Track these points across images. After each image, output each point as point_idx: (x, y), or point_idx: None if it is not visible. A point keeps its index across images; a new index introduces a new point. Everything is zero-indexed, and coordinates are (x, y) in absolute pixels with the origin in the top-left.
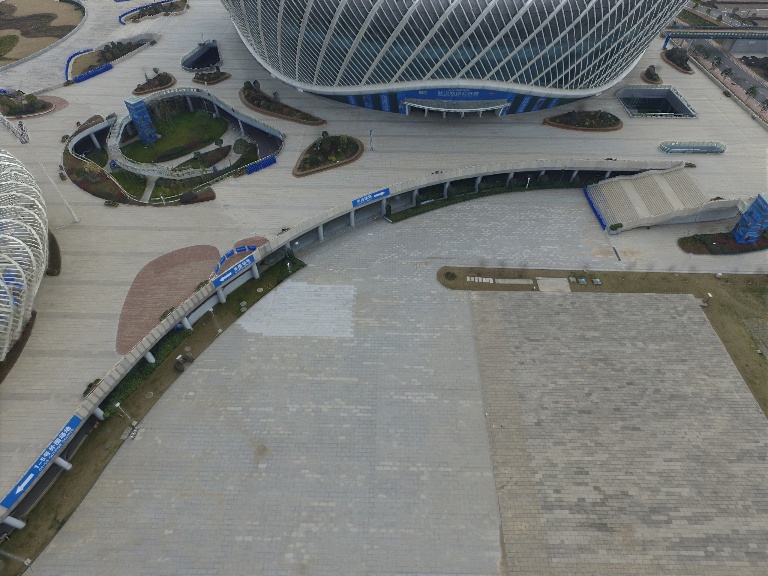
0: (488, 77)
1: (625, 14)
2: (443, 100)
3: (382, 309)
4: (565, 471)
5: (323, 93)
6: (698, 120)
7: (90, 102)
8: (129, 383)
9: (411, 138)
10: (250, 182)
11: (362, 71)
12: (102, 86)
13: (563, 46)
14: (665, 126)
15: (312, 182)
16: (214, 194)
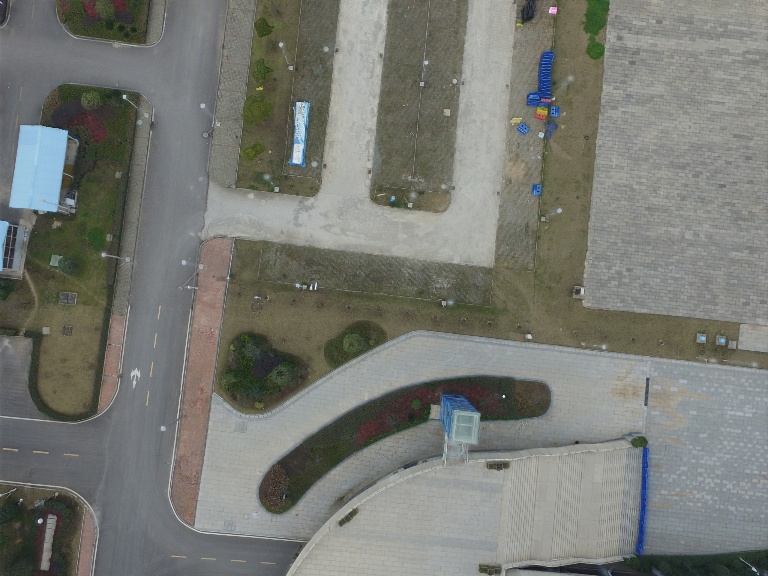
0: None
1: None
2: None
3: None
4: None
5: None
6: None
7: None
8: None
9: None
10: None
11: None
12: None
13: None
14: None
15: None
16: None
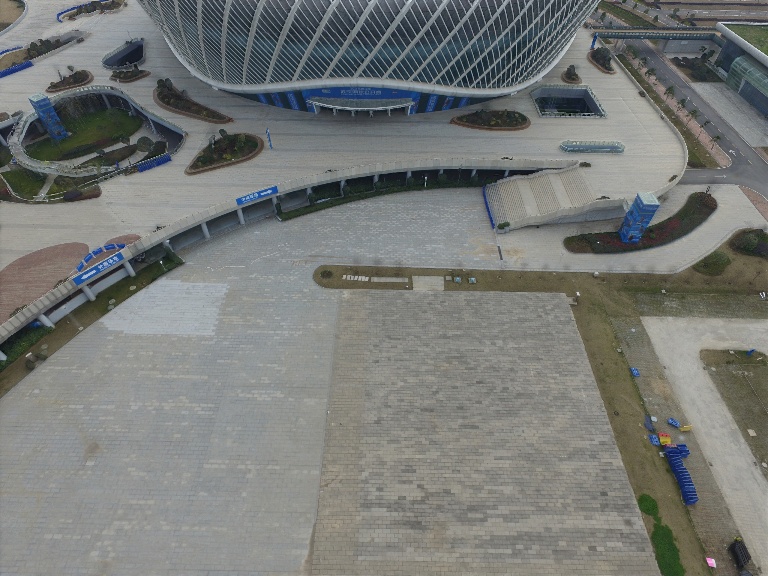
0: (386, 76)
1: (516, 13)
2: (347, 99)
3: (250, 307)
4: (393, 469)
5: (235, 91)
6: (606, 120)
7: (1, 99)
8: None
9: (314, 137)
10: (140, 180)
11: (263, 69)
12: (17, 83)
13: (457, 45)
14: (572, 126)
15: (202, 180)
16: (100, 192)
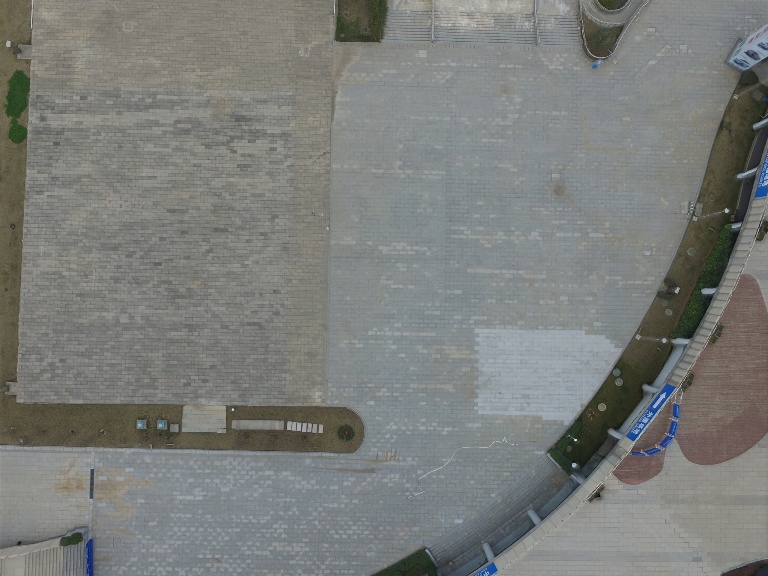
0: None
1: None
2: None
3: (440, 373)
4: (260, 168)
5: None
6: None
7: None
8: (719, 264)
9: None
10: None
11: None
12: None
13: None
14: None
15: None
16: None
